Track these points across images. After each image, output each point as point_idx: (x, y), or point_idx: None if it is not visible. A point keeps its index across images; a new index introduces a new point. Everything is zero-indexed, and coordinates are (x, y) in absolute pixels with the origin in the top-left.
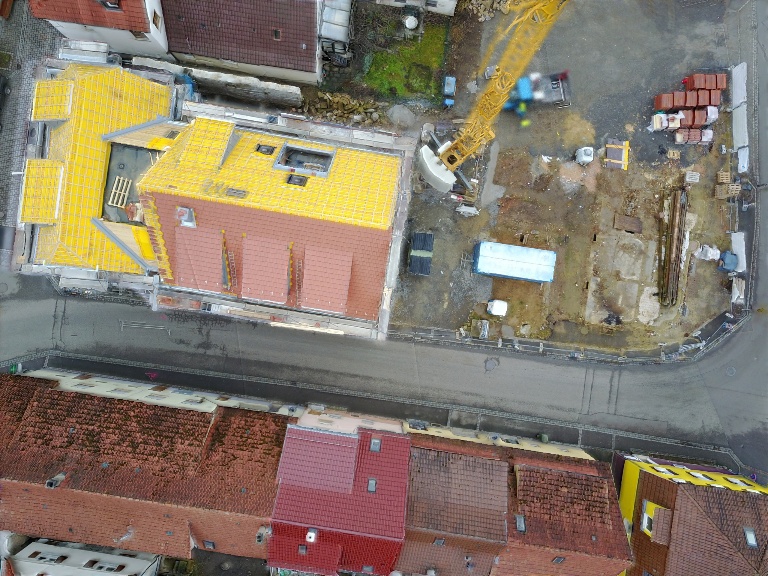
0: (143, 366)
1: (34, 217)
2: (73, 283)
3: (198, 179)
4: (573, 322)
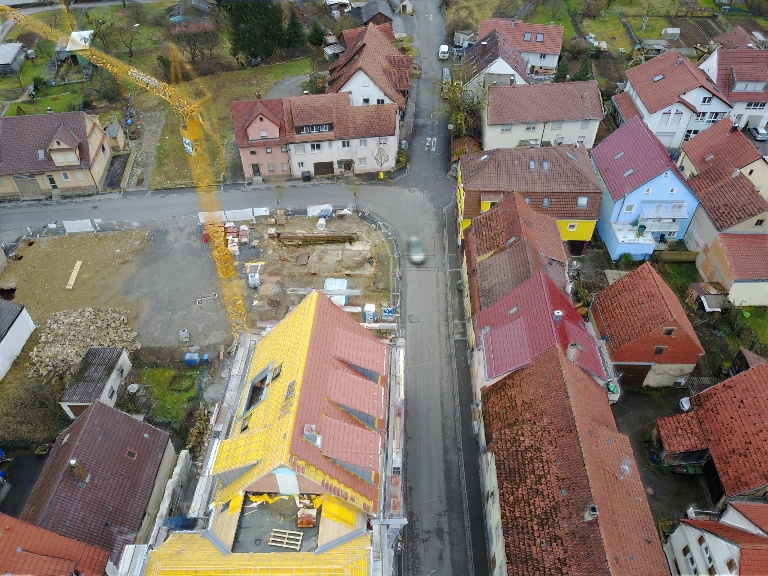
0: None
1: None
2: None
3: (276, 431)
4: (375, 279)
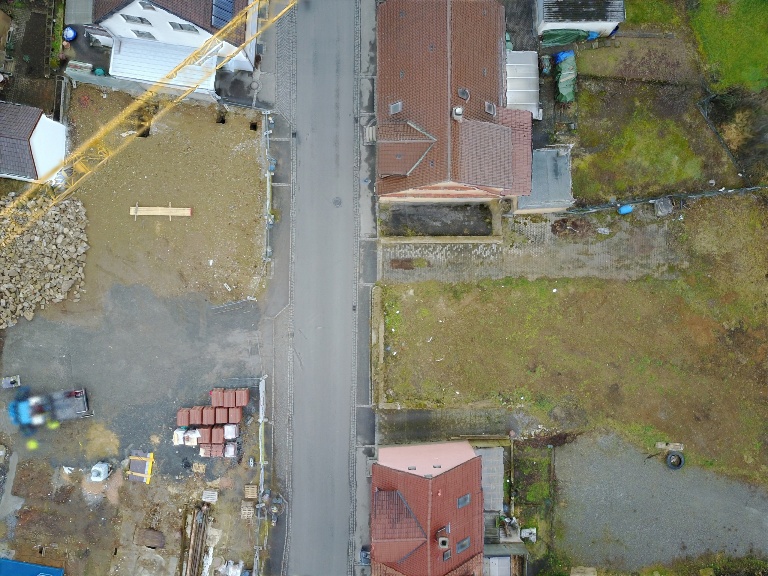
0: None
1: None
2: None
3: None
4: None
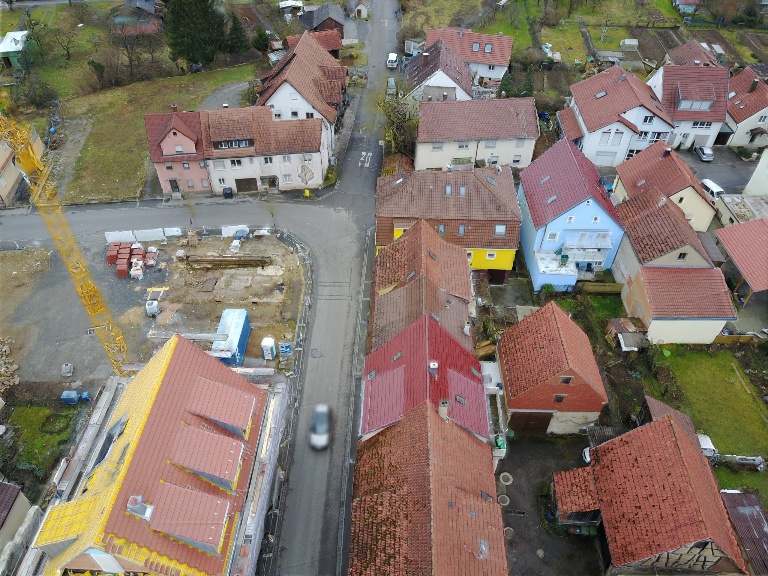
0: None
1: None
2: None
3: None
4: (282, 308)
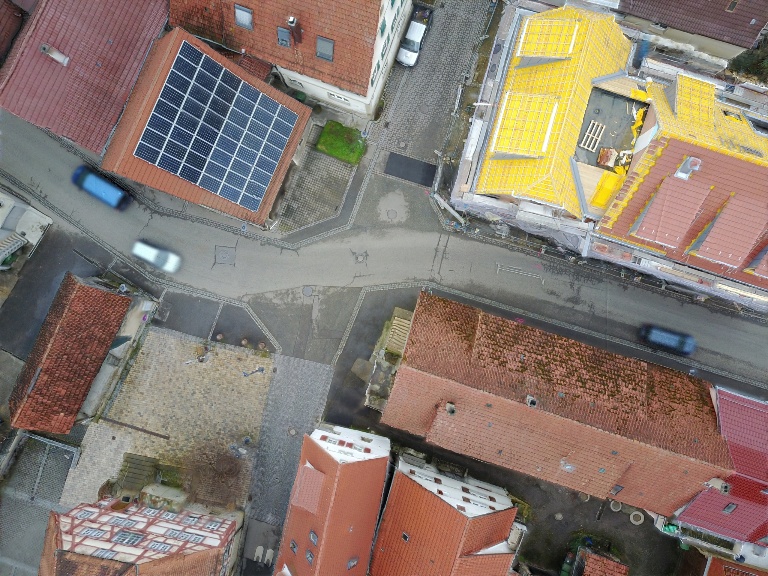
0: (513, 310)
1: (513, 148)
2: (529, 217)
3: None
4: None
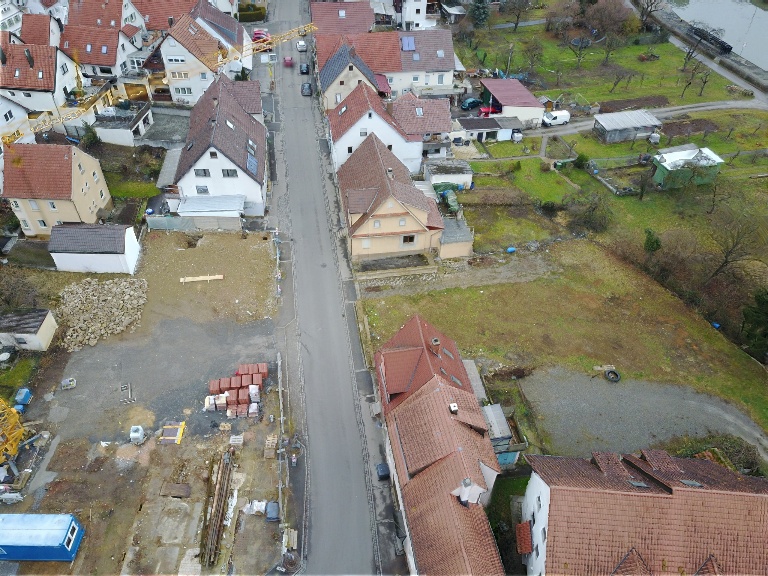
0: None
1: None
2: None
3: None
4: None
